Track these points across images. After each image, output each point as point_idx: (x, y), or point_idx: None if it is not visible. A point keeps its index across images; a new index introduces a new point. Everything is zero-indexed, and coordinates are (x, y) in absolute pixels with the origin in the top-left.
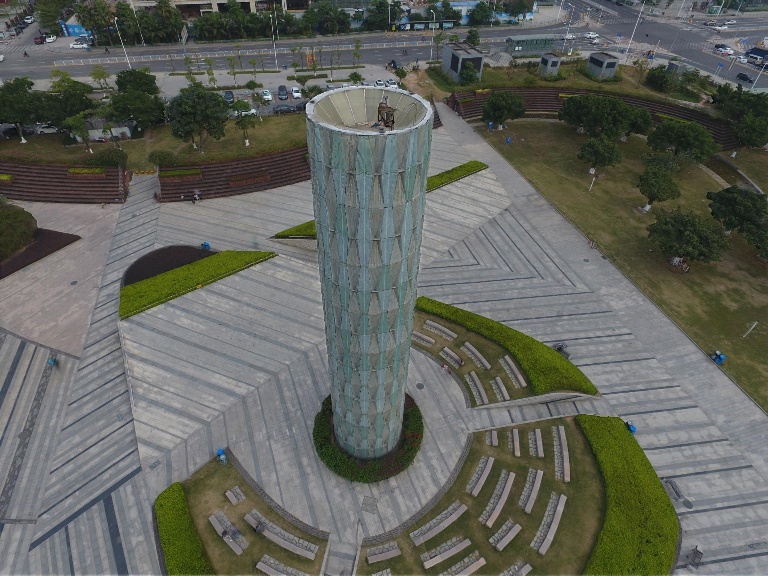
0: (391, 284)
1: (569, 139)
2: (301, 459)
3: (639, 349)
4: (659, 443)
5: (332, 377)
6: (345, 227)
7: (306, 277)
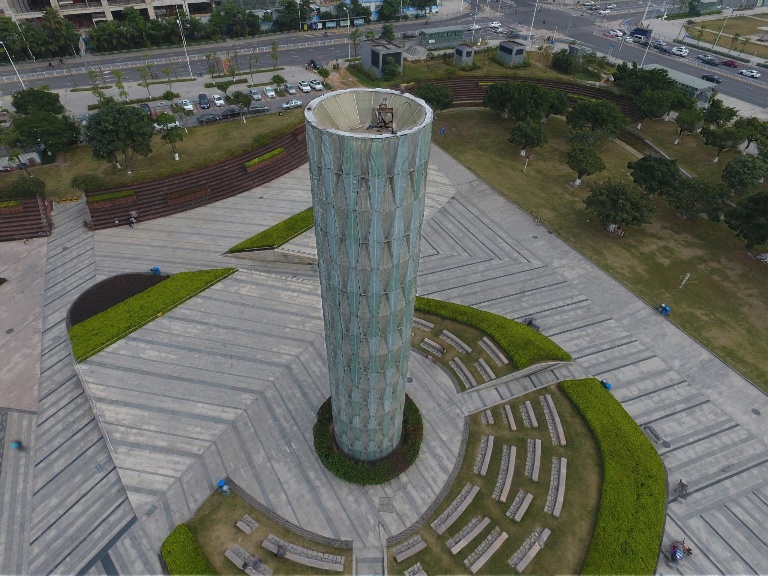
0: (400, 283)
1: (496, 125)
2: (307, 474)
3: (597, 312)
4: (632, 395)
5: (336, 385)
6: (356, 232)
7: (272, 289)
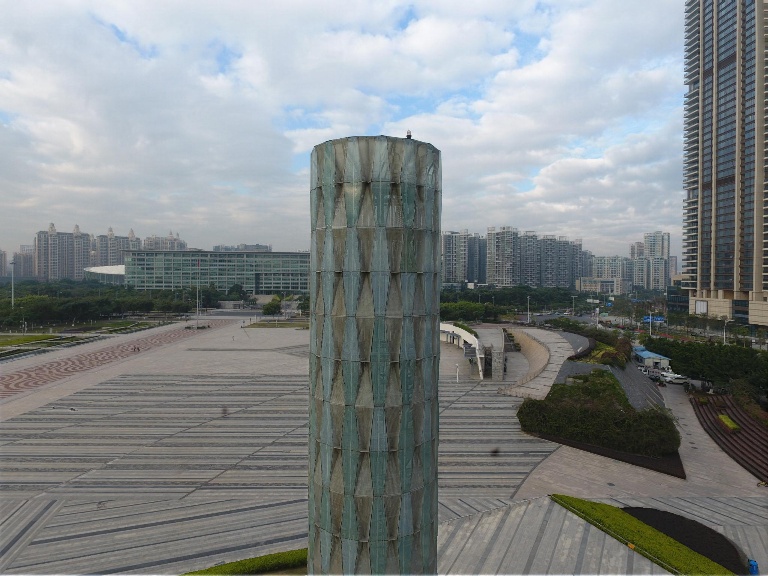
0: None
1: None
2: None
3: None
4: None
5: None
6: None
7: None
